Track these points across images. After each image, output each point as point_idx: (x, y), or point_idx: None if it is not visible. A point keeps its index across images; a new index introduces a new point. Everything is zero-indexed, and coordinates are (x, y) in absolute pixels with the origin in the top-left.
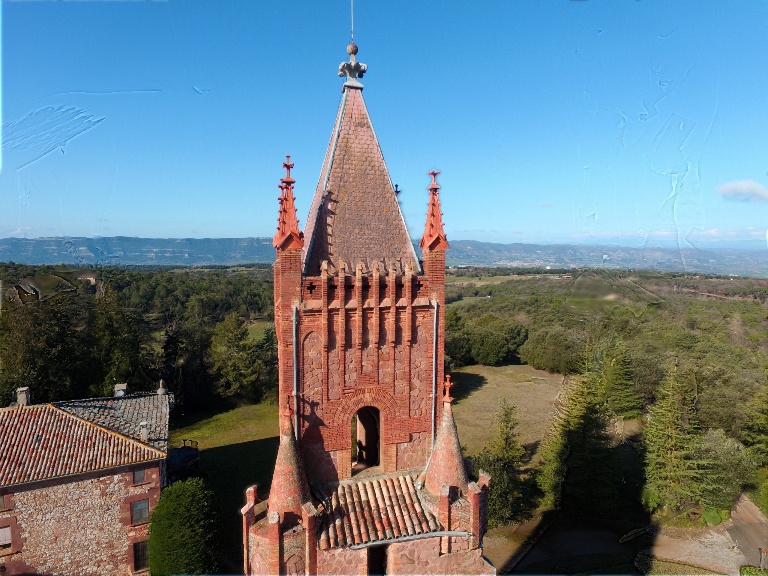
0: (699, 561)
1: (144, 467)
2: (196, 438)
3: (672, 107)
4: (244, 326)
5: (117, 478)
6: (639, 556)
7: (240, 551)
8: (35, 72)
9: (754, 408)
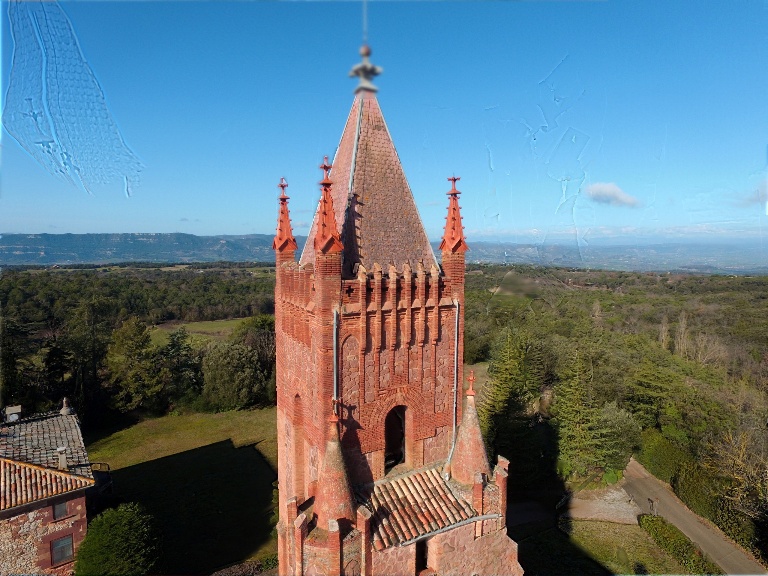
0: (607, 516)
1: (66, 499)
2: (96, 460)
3: (570, 122)
4: (146, 332)
5: (33, 515)
6: (560, 519)
7: (178, 575)
8: (325, 77)
9: (634, 382)
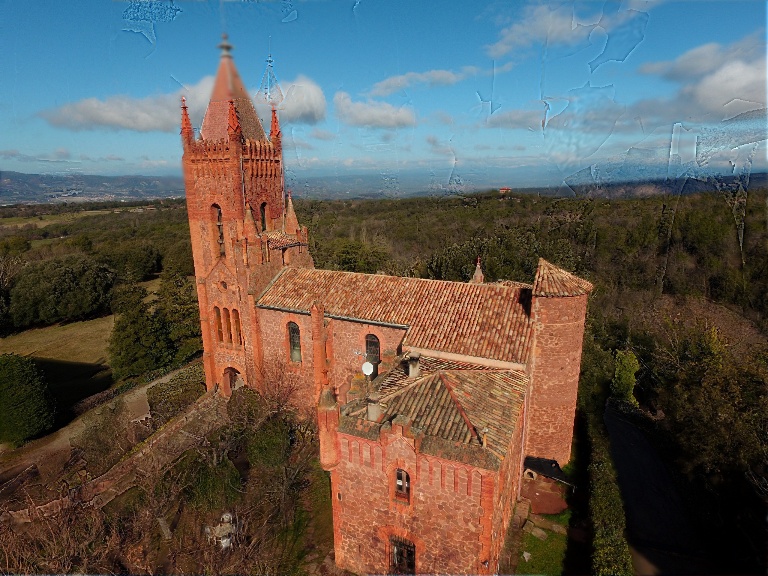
0: None
1: None
2: None
3: None
4: None
5: None
6: None
7: None
8: None
9: (340, 252)
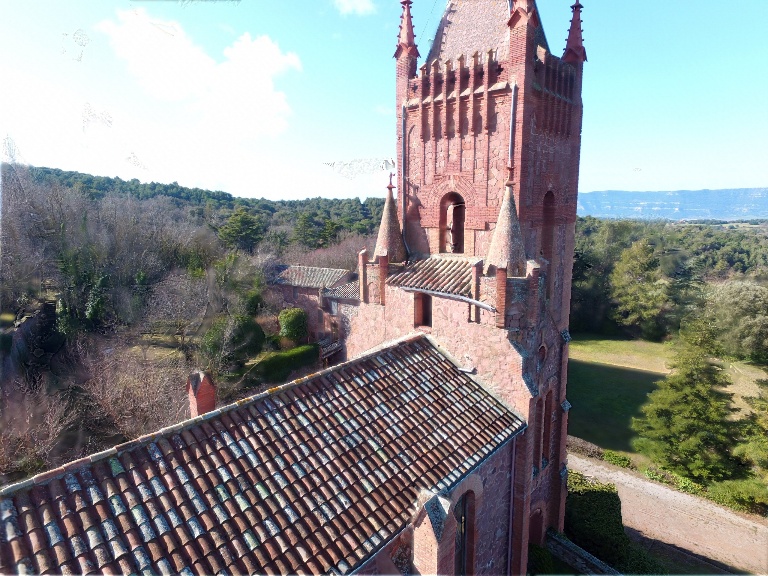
0: None
1: None
2: (576, 350)
3: None
4: (653, 255)
5: None
6: None
7: None
8: None
9: None
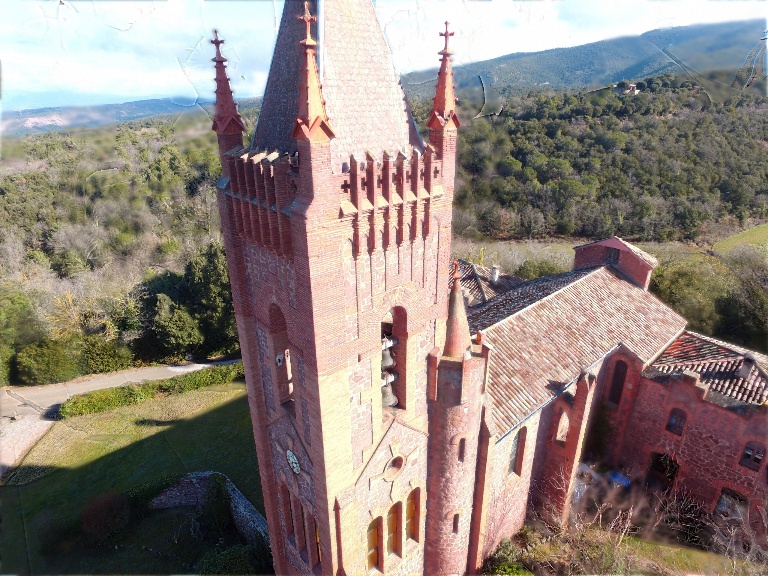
0: (25, 442)
1: None
2: None
3: None
4: None
5: None
6: (3, 484)
7: None
8: None
9: None
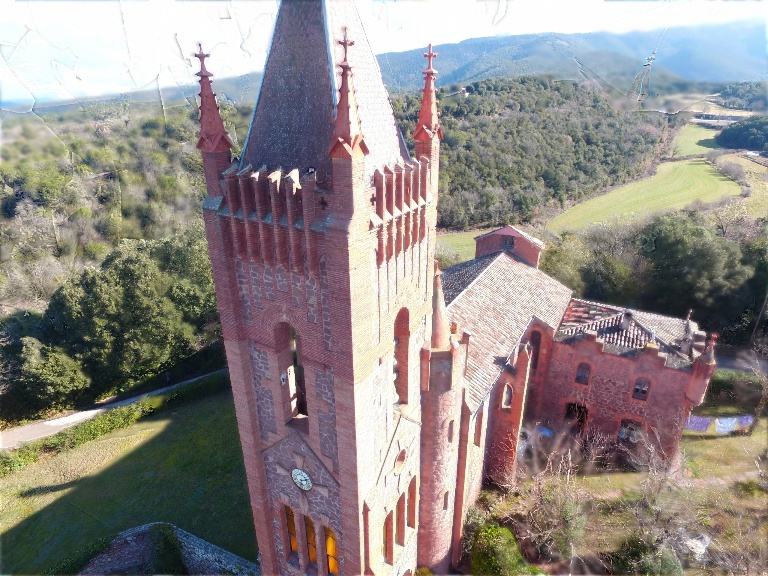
0: None
1: None
2: None
3: None
4: None
5: None
6: None
7: None
8: None
9: None
